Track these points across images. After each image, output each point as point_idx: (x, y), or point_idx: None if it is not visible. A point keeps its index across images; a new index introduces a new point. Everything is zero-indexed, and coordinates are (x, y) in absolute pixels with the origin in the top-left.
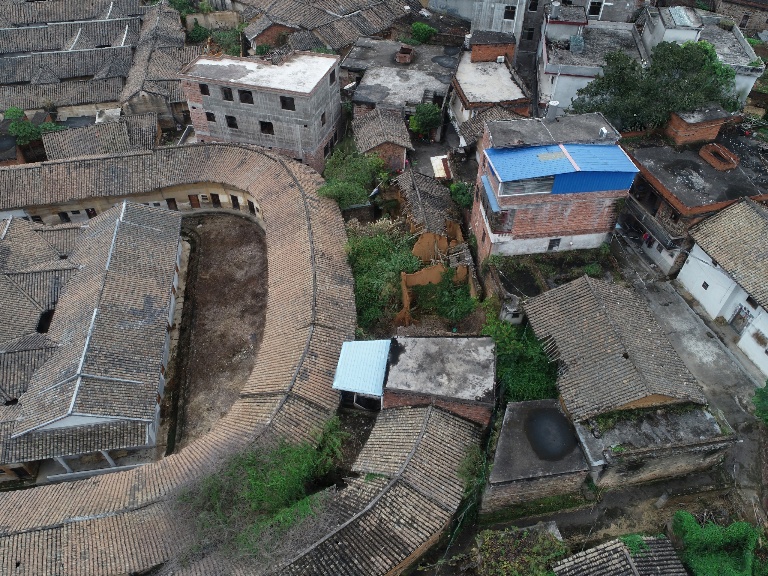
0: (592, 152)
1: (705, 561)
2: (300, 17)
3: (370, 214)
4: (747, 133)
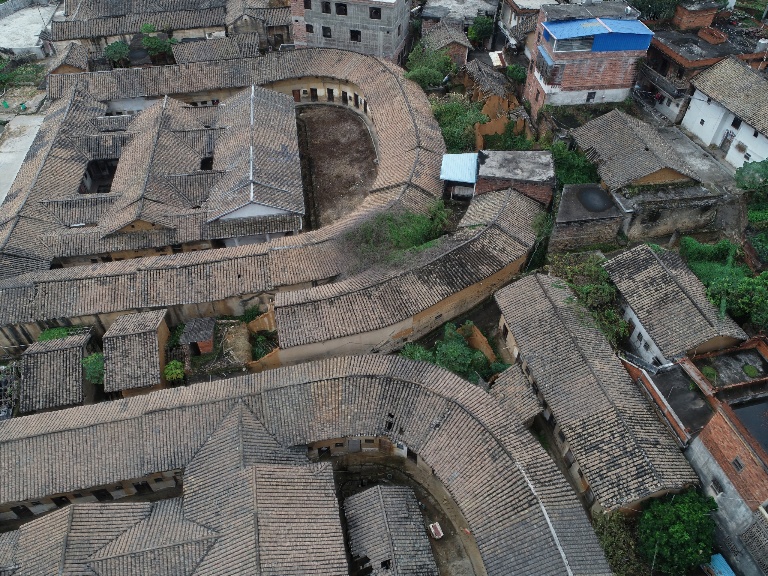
0: (620, 23)
1: (701, 264)
2: None
3: (442, 96)
4: (734, 23)
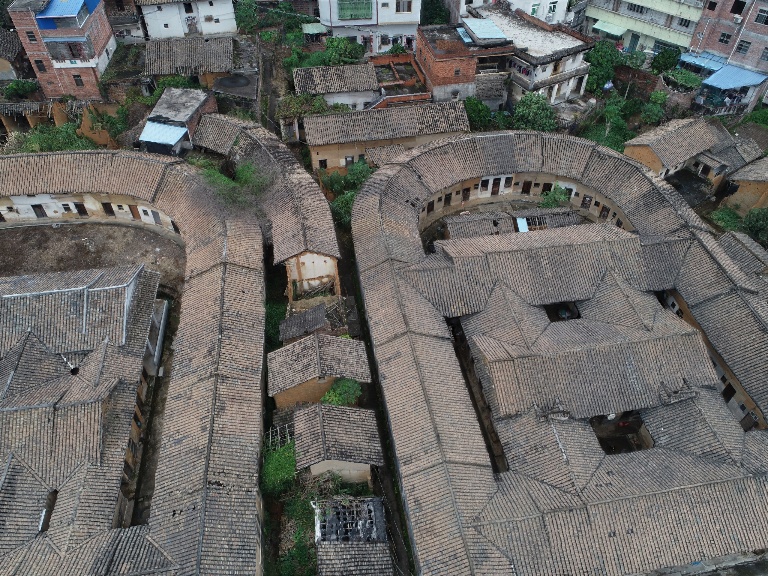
0: None
1: (303, 65)
2: None
3: None
4: None
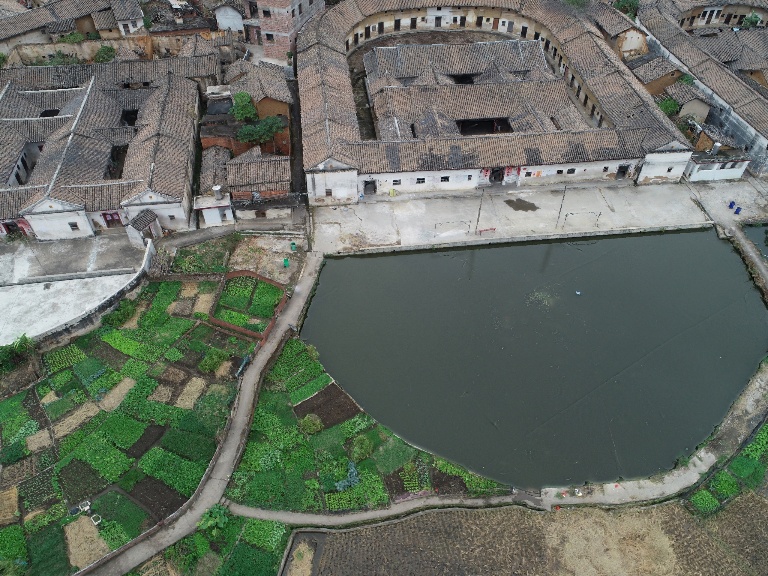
0: None
1: None
2: (99, 2)
3: None
4: None
